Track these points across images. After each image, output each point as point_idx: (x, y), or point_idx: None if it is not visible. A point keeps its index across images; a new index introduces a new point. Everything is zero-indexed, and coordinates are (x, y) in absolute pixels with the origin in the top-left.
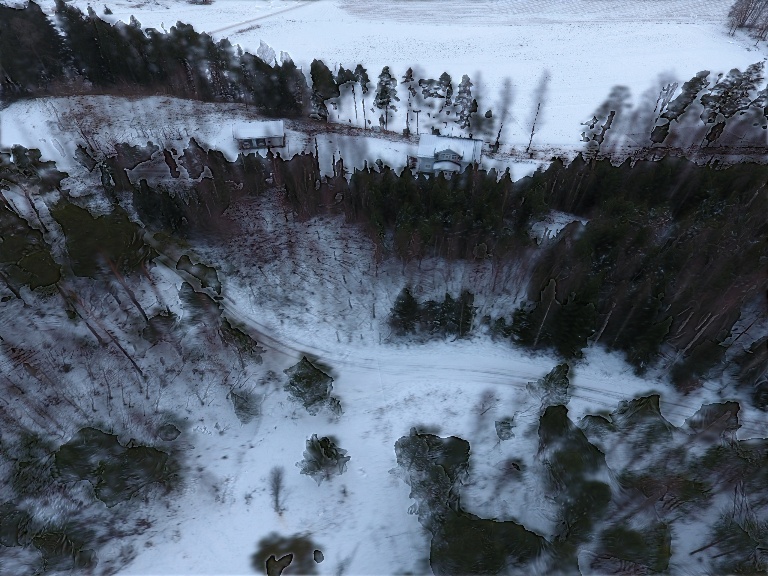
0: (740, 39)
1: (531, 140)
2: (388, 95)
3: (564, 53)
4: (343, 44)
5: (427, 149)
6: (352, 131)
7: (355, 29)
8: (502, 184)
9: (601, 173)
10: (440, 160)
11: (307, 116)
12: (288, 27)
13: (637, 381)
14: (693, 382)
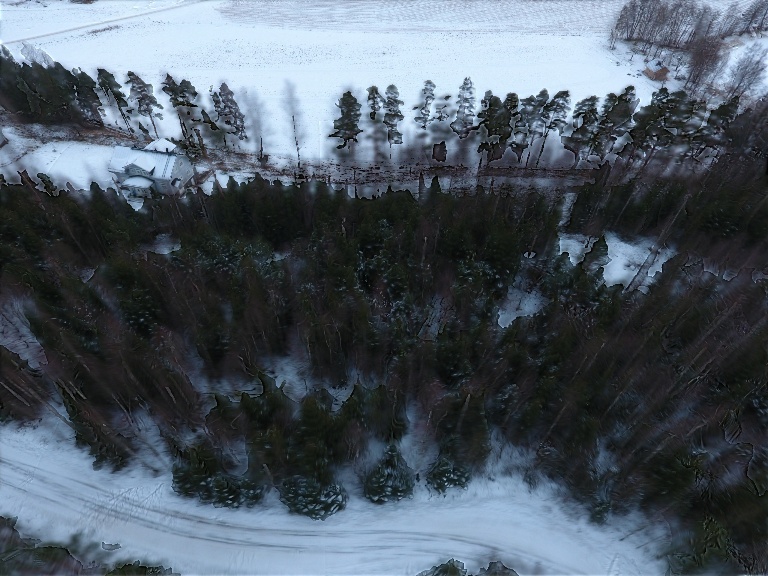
0: (618, 53)
1: (299, 155)
2: (148, 102)
3: (422, 63)
4: (199, 47)
5: (119, 163)
6: (108, 139)
7: (221, 32)
8: (72, 208)
9: (233, 197)
10: (134, 175)
11: (76, 122)
12: (151, 28)
13: (70, 452)
14: (101, 459)
